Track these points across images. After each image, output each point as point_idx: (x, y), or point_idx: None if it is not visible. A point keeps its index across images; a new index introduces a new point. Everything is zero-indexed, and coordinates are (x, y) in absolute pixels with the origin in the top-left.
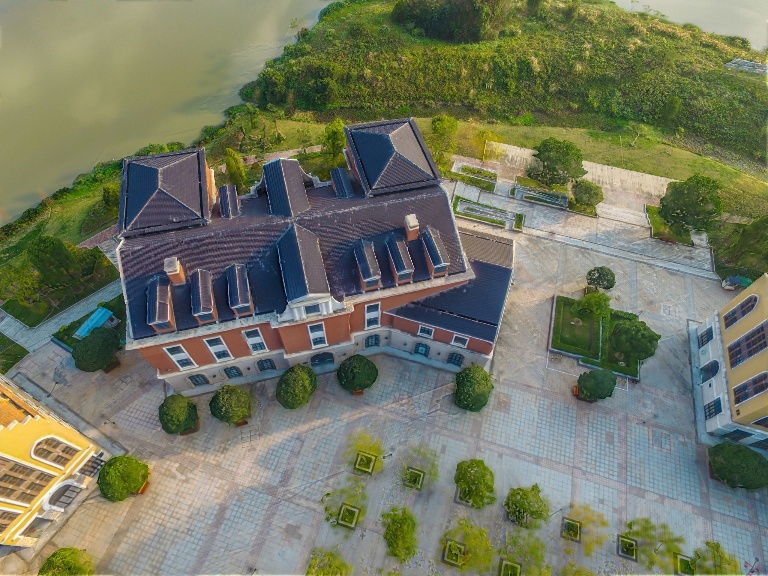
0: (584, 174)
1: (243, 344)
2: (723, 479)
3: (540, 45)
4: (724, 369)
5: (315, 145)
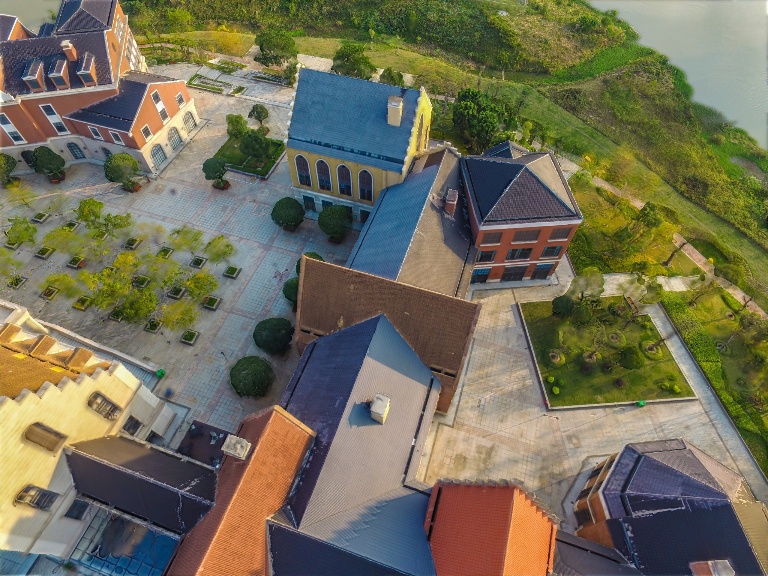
0: (293, 56)
1: None
2: (274, 220)
3: None
4: None
5: None
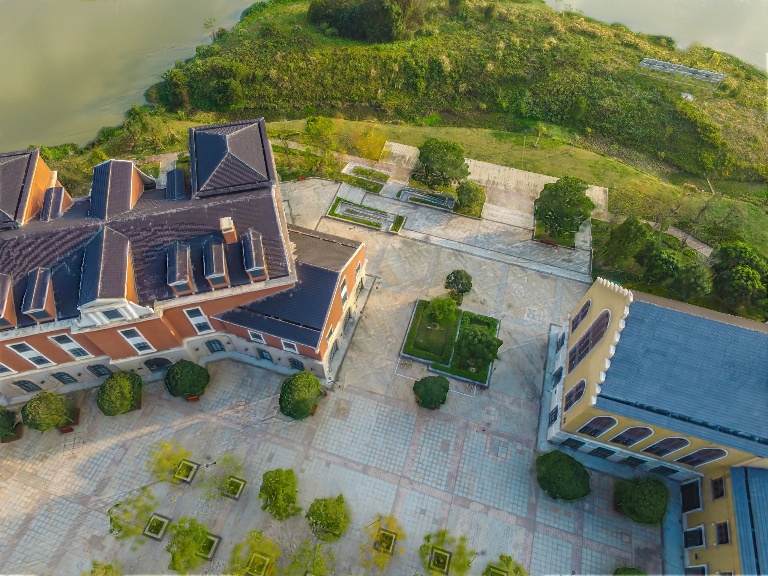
0: (466, 175)
1: (58, 350)
2: (544, 489)
3: (455, 45)
4: (564, 375)
5: None
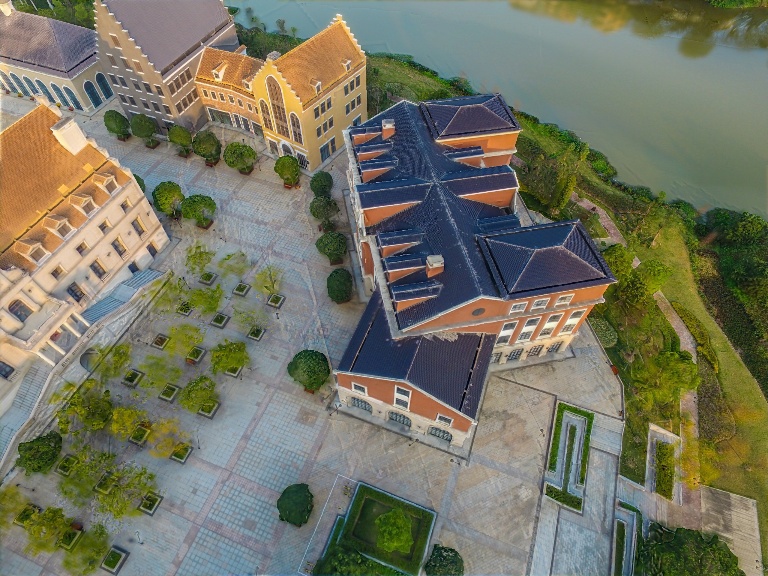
0: None
1: None
2: None
3: None
4: None
5: None
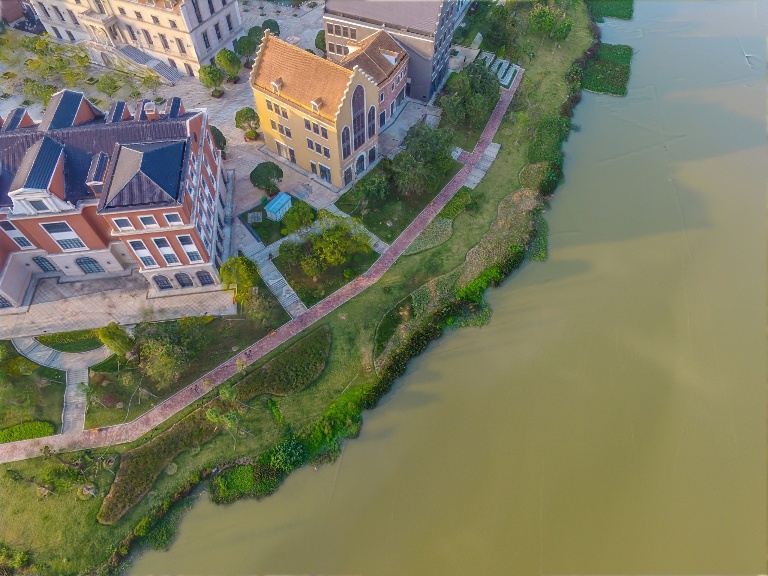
0: None
1: None
2: None
3: None
4: None
5: (1, 465)
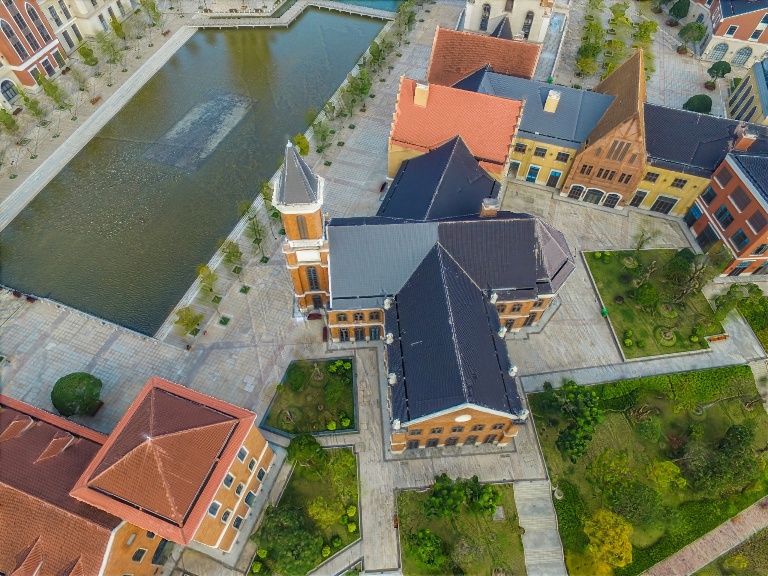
0: None
1: None
2: None
3: None
4: None
5: None
